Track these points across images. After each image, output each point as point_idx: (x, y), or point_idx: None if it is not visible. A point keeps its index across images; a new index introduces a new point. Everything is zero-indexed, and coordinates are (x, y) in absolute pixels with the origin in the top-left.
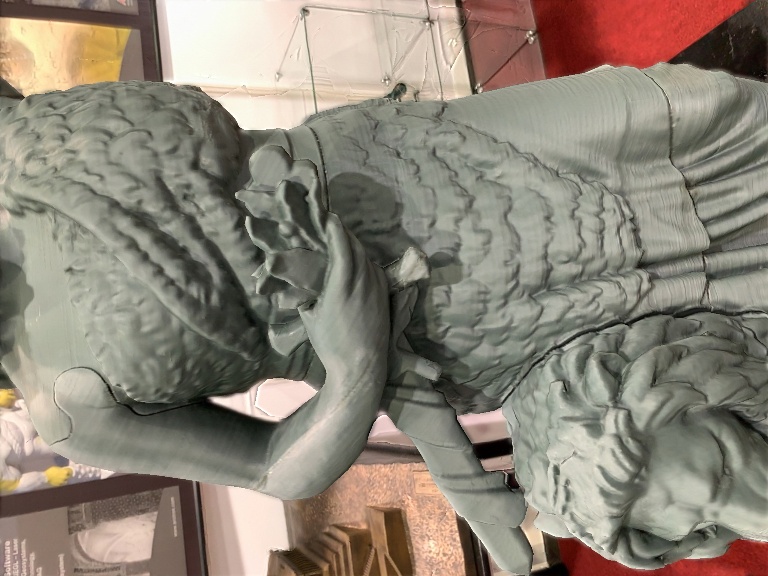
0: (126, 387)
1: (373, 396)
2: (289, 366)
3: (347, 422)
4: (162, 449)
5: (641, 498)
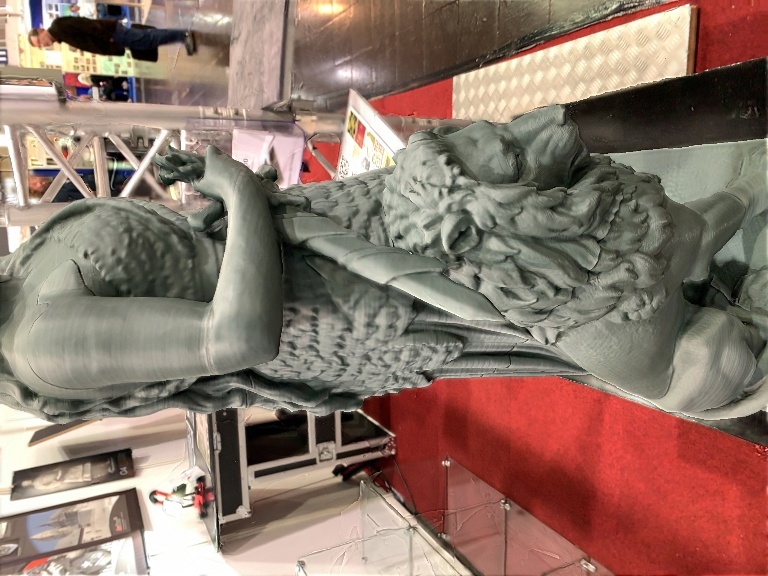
0: (90, 251)
1: (255, 188)
2: (218, 271)
3: (244, 205)
4: (121, 305)
5: (454, 148)
